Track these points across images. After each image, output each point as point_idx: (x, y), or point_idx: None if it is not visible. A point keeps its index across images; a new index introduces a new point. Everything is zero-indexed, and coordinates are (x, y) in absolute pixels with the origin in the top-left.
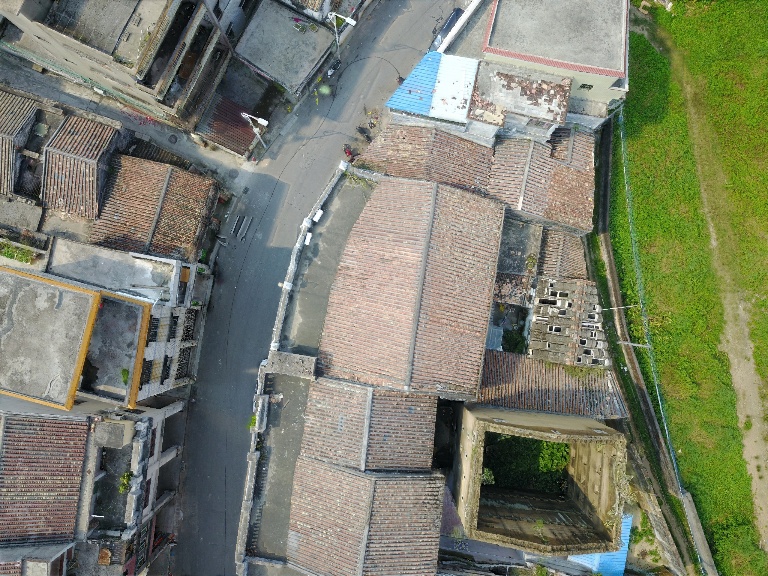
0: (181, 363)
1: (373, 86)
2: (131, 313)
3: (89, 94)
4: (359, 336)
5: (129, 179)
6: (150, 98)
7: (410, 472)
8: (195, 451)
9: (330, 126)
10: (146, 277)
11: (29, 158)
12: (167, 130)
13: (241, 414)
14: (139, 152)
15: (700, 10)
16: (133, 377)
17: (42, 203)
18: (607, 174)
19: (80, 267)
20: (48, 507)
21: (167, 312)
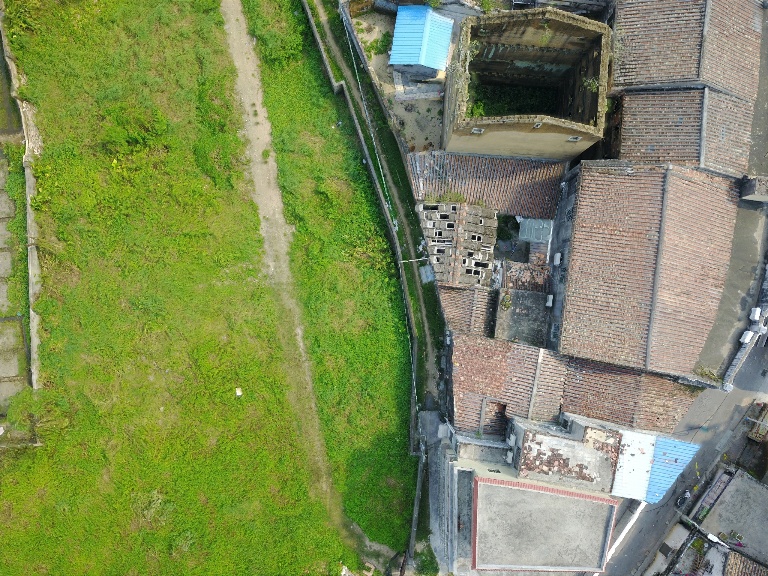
0: None
1: None
2: None
3: None
4: (706, 219)
5: None
6: None
7: (650, 90)
8: None
9: None
10: None
11: None
12: None
13: None
14: None
15: (313, 568)
16: None
17: None
18: None
19: None
20: None
21: None
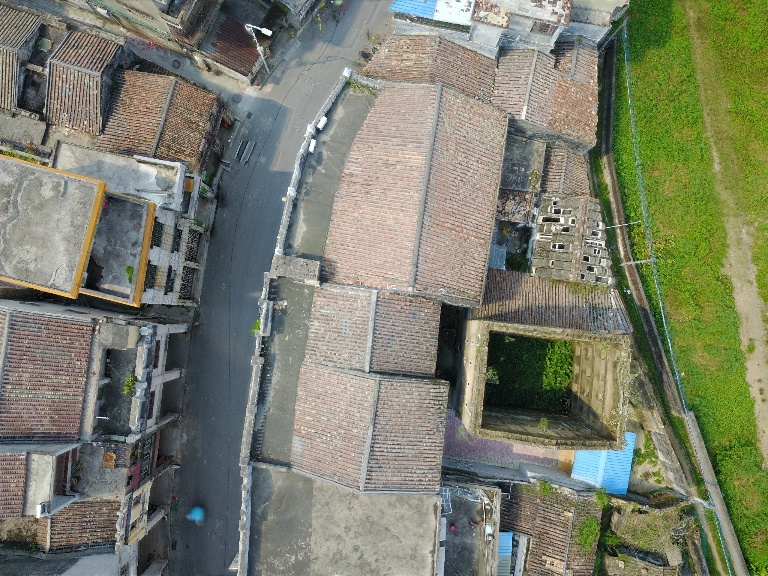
0: (185, 284)
1: (376, 11)
2: (136, 212)
3: (92, 19)
4: (363, 241)
5: (133, 93)
6: (154, 8)
7: (414, 377)
8: (198, 374)
9: (333, 51)
10: (150, 182)
11: (33, 73)
12: (170, 55)
13: (244, 337)
14: (143, 71)
15: None
16: (138, 275)
17: (46, 118)
18: (610, 95)
19: (84, 172)
20: (53, 406)
21: (171, 221)
